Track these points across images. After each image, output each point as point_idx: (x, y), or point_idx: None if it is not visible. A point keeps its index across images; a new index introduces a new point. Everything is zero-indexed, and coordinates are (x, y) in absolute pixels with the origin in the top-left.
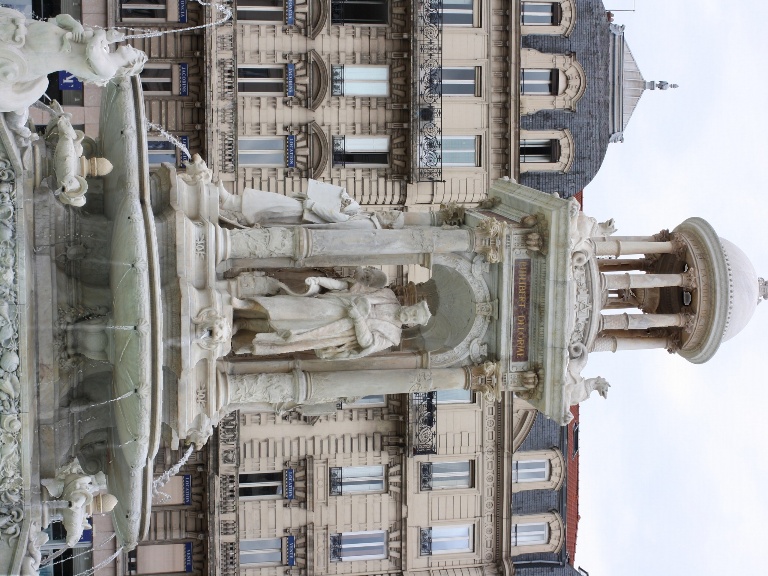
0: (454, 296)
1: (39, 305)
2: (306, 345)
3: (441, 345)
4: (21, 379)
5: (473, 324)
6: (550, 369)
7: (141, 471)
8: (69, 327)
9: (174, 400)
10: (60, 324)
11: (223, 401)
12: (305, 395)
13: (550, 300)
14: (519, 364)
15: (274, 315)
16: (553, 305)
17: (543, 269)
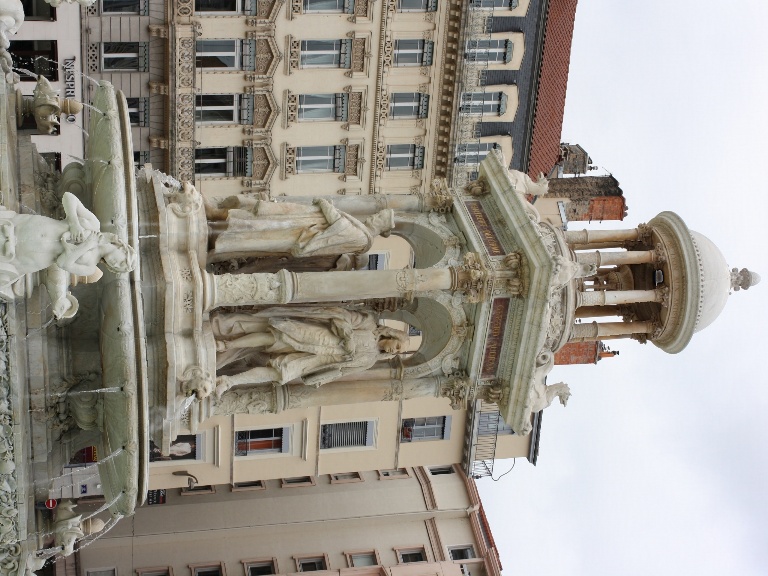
0: None
1: (21, 156)
2: (278, 220)
3: (439, 346)
4: (0, 128)
5: (445, 252)
6: (525, 240)
7: (129, 291)
8: (49, 178)
9: (158, 266)
10: None
11: (209, 283)
12: (291, 280)
13: (504, 204)
14: (498, 257)
15: (242, 198)
16: (508, 206)
17: (492, 200)
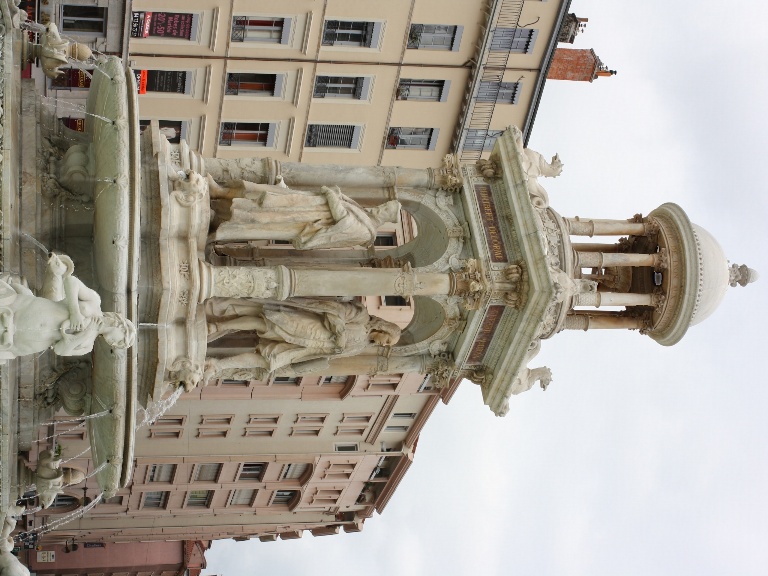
0: (428, 250)
1: (24, 130)
2: (283, 214)
3: (429, 330)
4: (4, 125)
5: (448, 245)
6: (529, 253)
7: (125, 304)
8: (52, 158)
9: (157, 262)
10: (43, 152)
11: (207, 280)
12: (289, 281)
13: (514, 200)
14: (500, 265)
15: (248, 184)
16: (518, 204)
17: (502, 188)
